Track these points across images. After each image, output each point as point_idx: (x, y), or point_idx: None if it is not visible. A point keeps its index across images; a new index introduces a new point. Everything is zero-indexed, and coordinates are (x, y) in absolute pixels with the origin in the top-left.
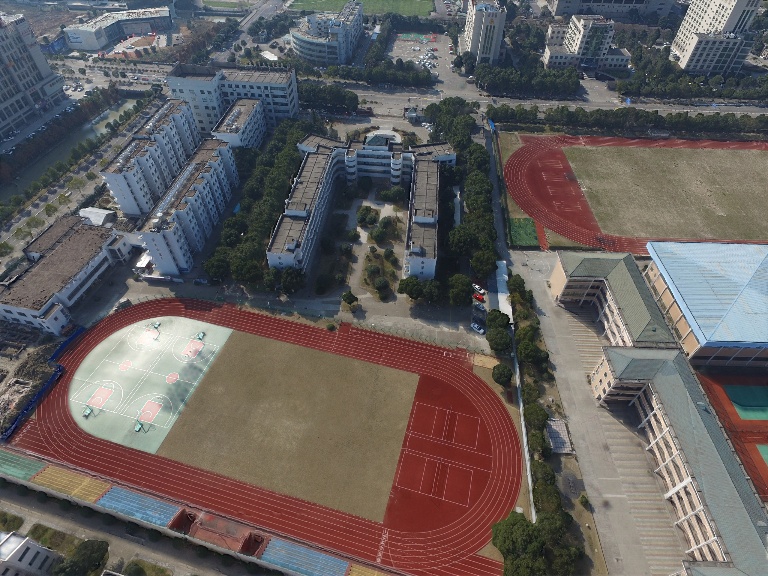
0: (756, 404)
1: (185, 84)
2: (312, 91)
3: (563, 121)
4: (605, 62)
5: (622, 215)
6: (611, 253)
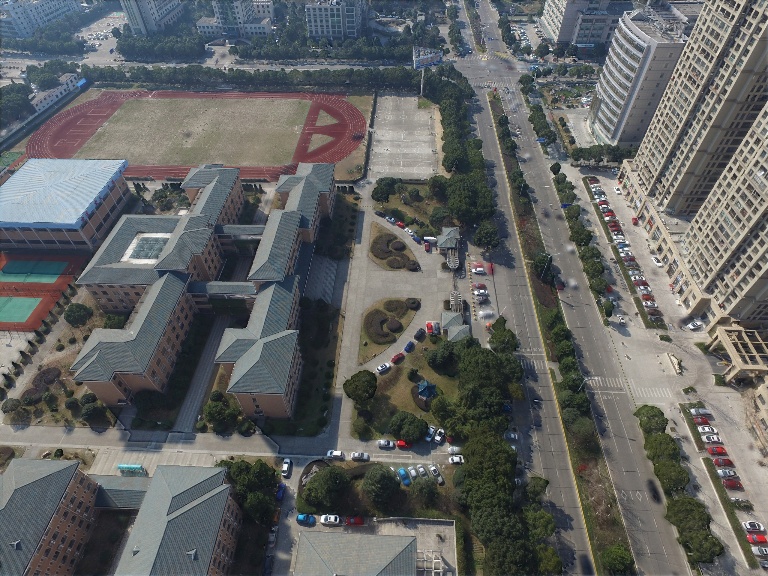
0: (17, 272)
1: None
2: None
3: (143, 78)
4: (246, 30)
5: (103, 148)
6: None
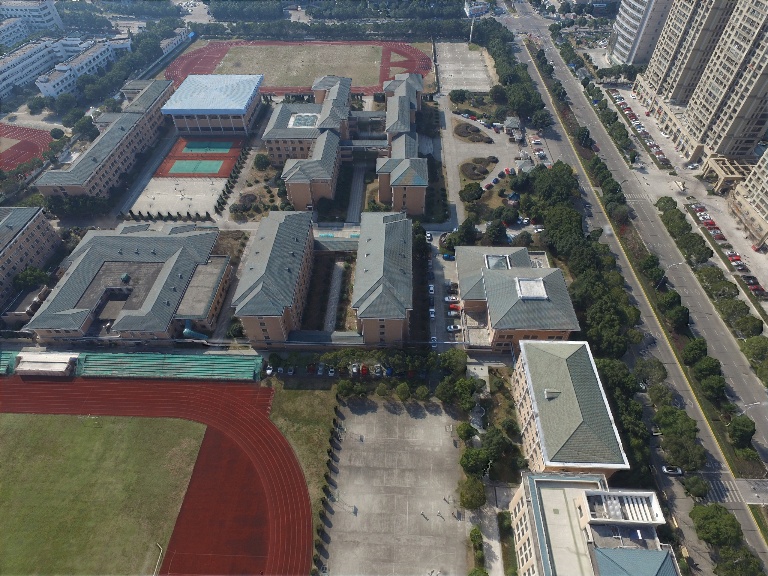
0: (198, 147)
1: None
2: (73, 16)
3: (242, 31)
4: None
5: None
6: None
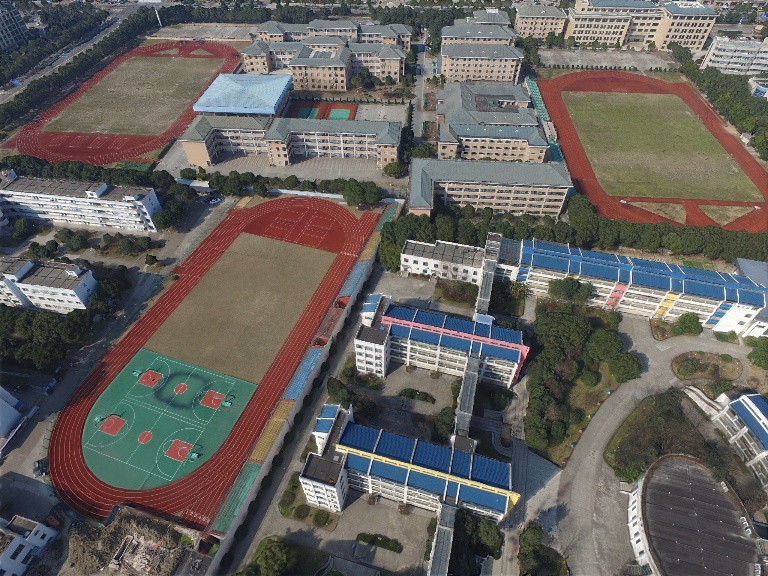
0: None
1: None
2: None
3: (8, 118)
4: None
5: (147, 124)
6: (193, 121)
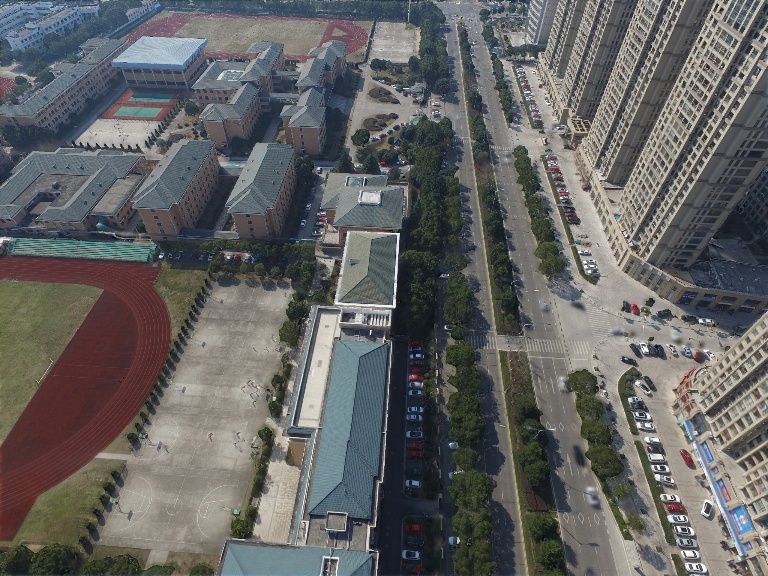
0: (142, 97)
1: None
2: None
3: (203, 4)
4: None
5: None
6: None
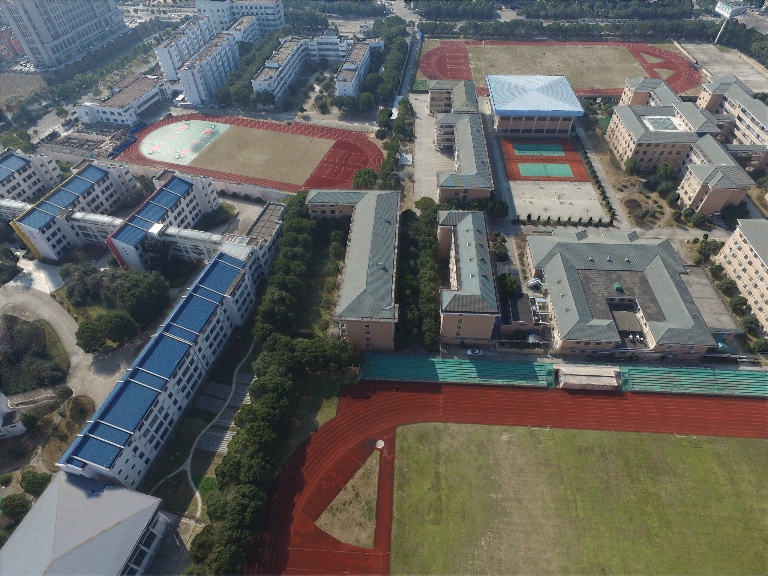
0: (528, 150)
1: (207, 5)
2: (295, 14)
3: (471, 30)
4: None
5: None
6: None
